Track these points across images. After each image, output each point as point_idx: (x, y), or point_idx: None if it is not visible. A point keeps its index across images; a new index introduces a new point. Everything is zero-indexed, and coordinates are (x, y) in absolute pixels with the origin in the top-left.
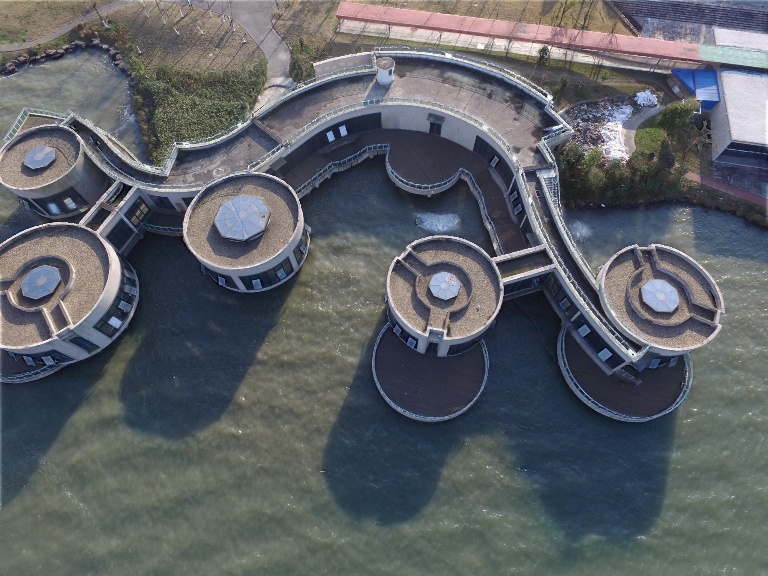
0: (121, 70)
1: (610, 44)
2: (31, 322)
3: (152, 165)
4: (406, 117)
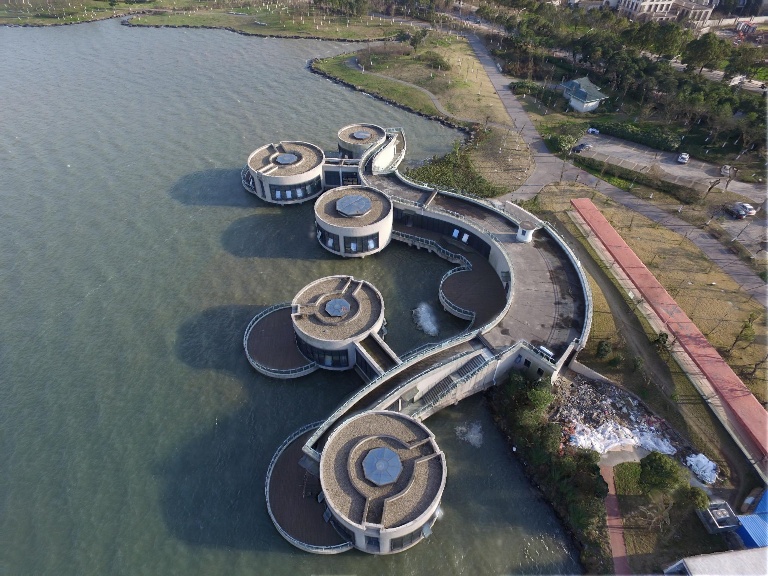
0: None
1: (728, 390)
2: (264, 164)
3: None
4: (501, 264)
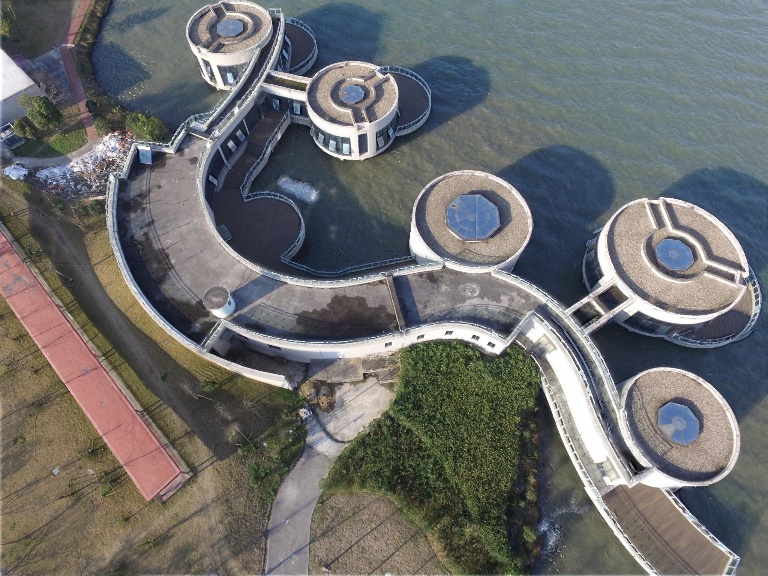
0: None
1: None
2: (683, 227)
3: None
4: None
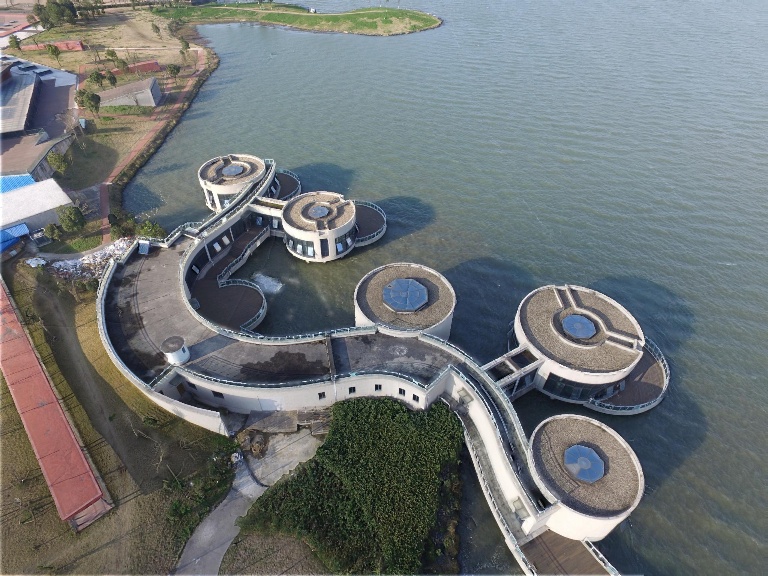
0: None
1: None
2: (587, 307)
3: None
4: None
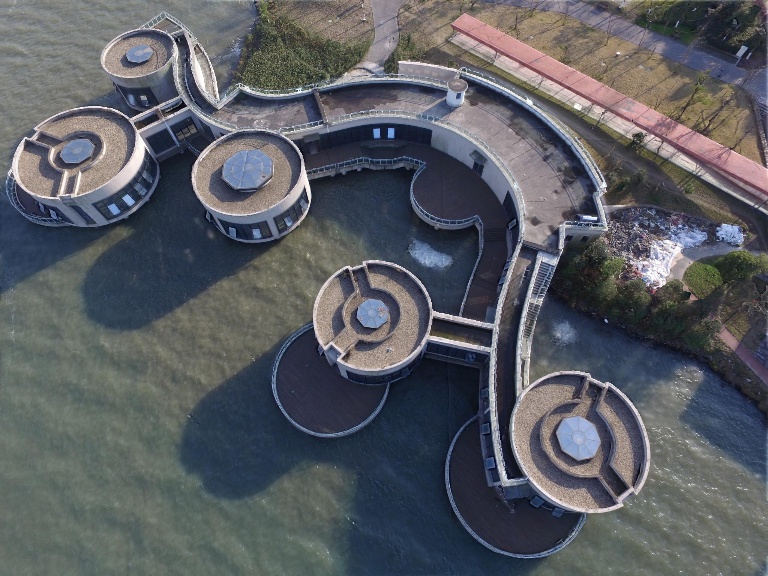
0: (256, 8)
1: (717, 158)
2: (53, 178)
3: (224, 96)
4: (455, 144)
